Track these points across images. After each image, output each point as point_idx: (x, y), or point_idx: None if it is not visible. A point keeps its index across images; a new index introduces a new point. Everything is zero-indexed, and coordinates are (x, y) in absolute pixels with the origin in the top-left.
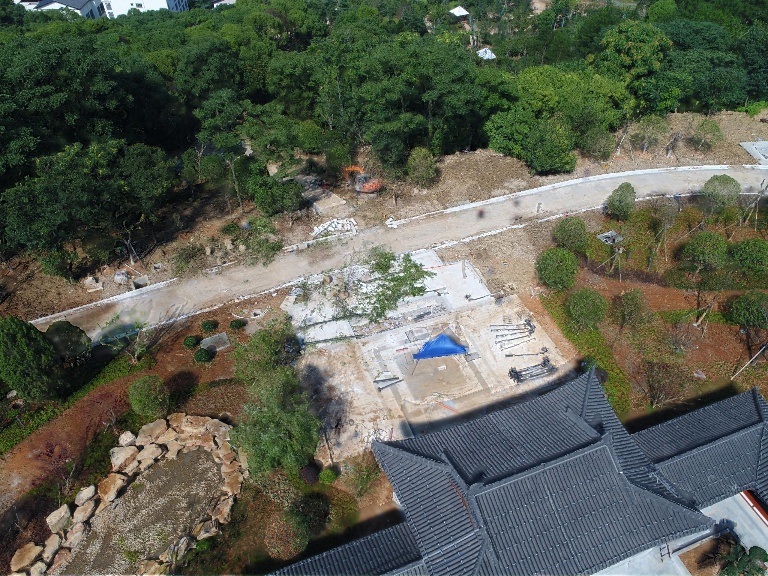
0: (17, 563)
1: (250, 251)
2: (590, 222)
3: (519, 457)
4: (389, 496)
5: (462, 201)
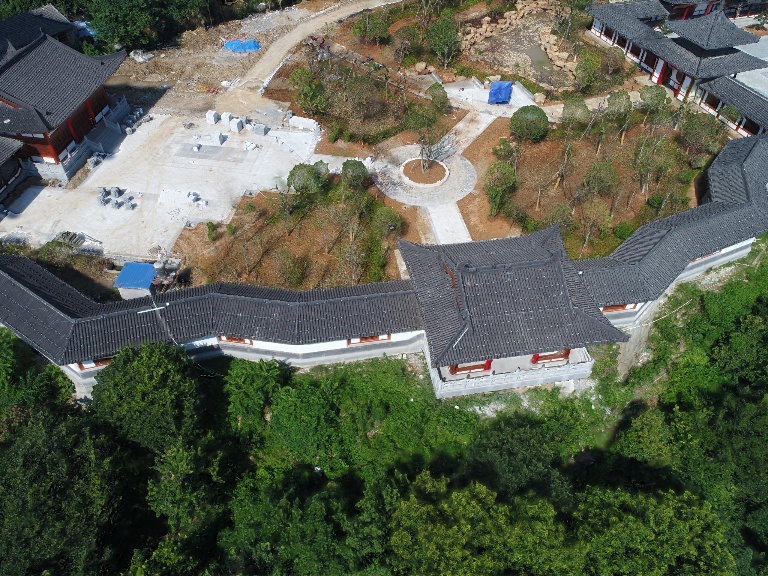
0: (501, 21)
1: None
2: None
3: None
4: None
5: None
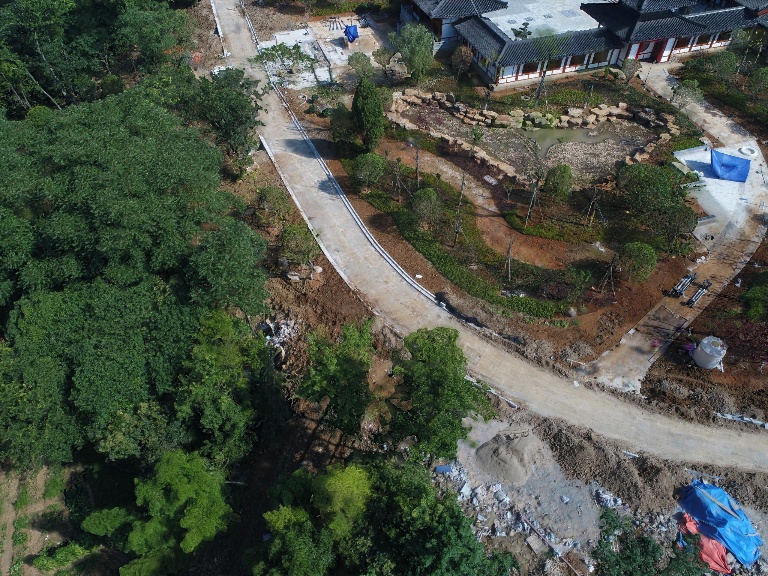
0: None
1: None
2: None
3: None
4: None
5: None
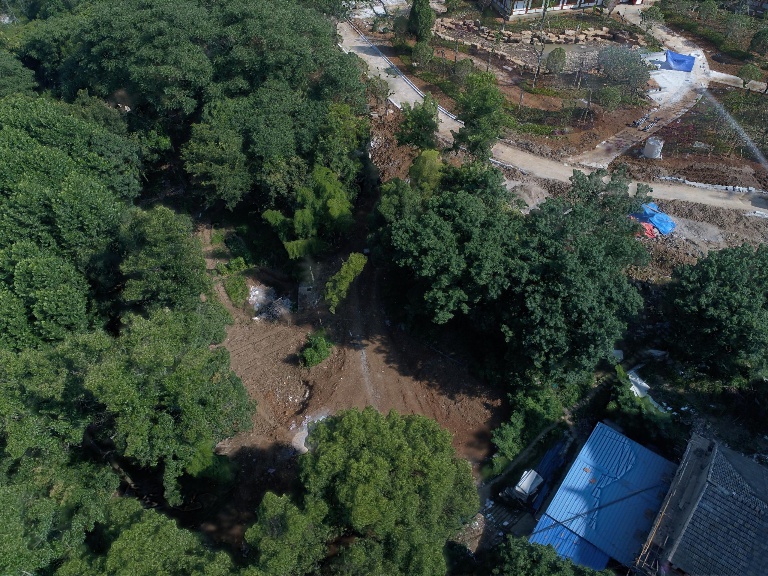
0: None
1: None
2: None
3: None
4: (461, 1)
5: None
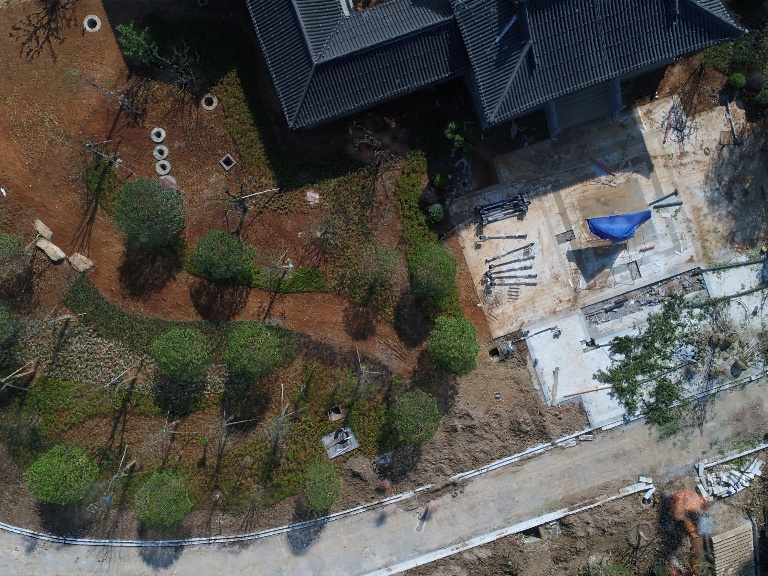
0: None
1: None
2: (362, 473)
3: (606, 1)
4: (672, 67)
5: (534, 542)
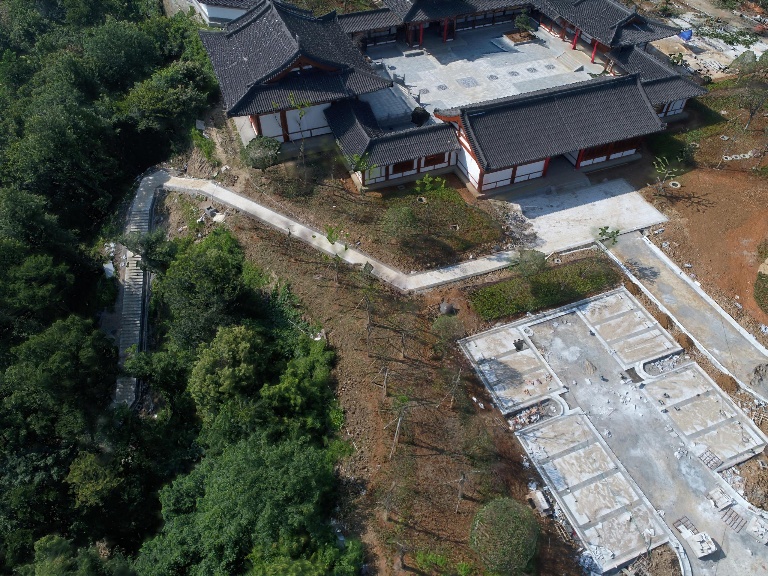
0: None
1: (723, 3)
2: None
3: None
4: None
5: None
